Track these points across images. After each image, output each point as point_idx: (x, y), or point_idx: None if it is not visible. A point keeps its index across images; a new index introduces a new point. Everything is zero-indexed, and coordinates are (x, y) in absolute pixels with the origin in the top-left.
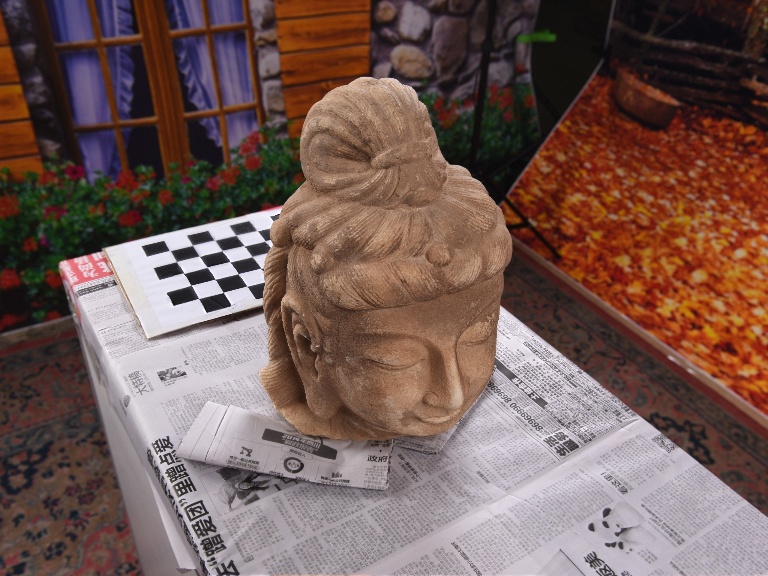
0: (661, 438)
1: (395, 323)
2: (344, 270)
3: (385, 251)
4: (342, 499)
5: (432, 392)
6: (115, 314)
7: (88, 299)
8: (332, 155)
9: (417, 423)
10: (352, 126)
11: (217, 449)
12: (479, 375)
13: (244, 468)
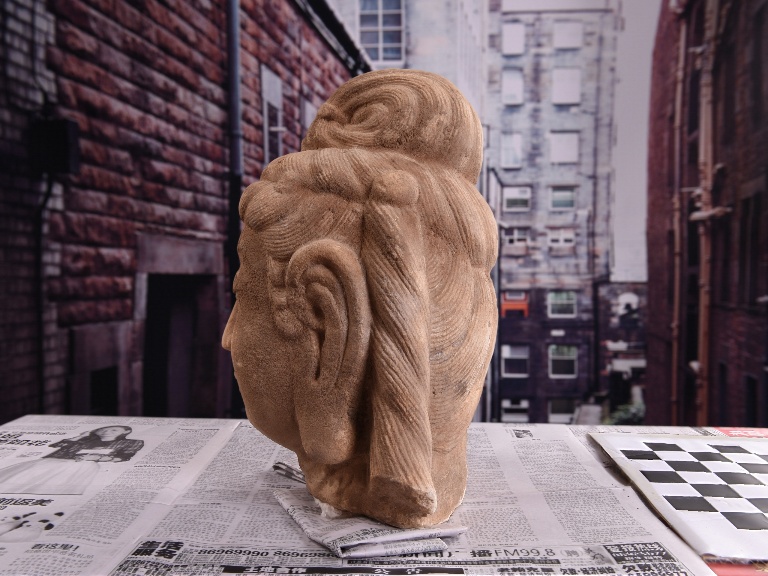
0: None
1: None
2: None
3: None
4: None
5: None
6: (645, 431)
7: None
8: None
9: None
10: None
11: None
12: None
13: None
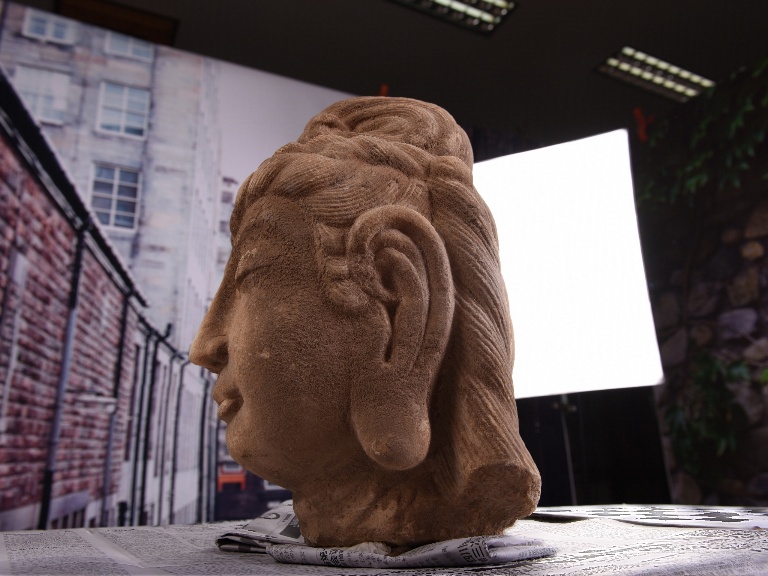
0: None
1: None
2: None
3: None
4: None
5: None
6: None
7: None
8: None
9: None
10: None
11: None
12: None
13: None
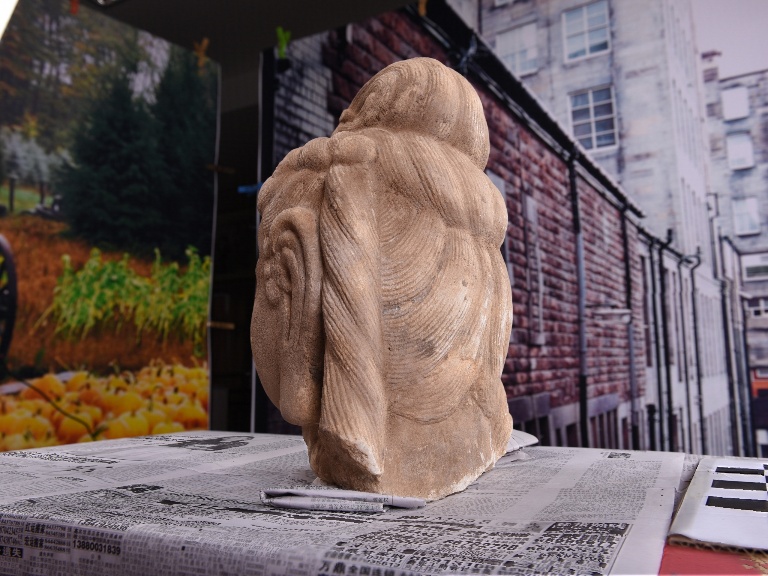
0: None
1: None
2: None
3: None
4: None
5: None
6: None
7: None
8: None
9: None
10: None
11: None
12: None
13: None
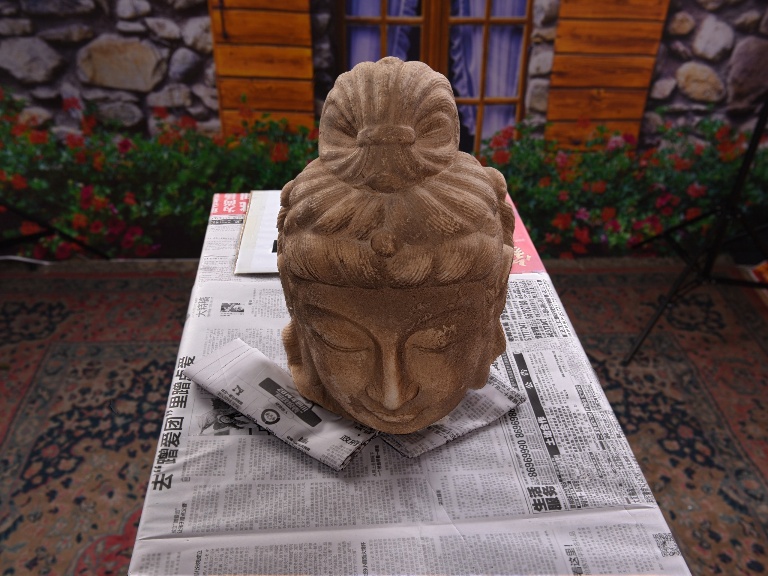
0: (665, 537)
1: (333, 301)
2: (300, 237)
3: (333, 227)
4: (297, 463)
5: (373, 385)
6: (225, 246)
7: (213, 229)
8: (334, 127)
9: (369, 414)
10: (348, 100)
11: (216, 379)
12: (433, 386)
13: (229, 403)
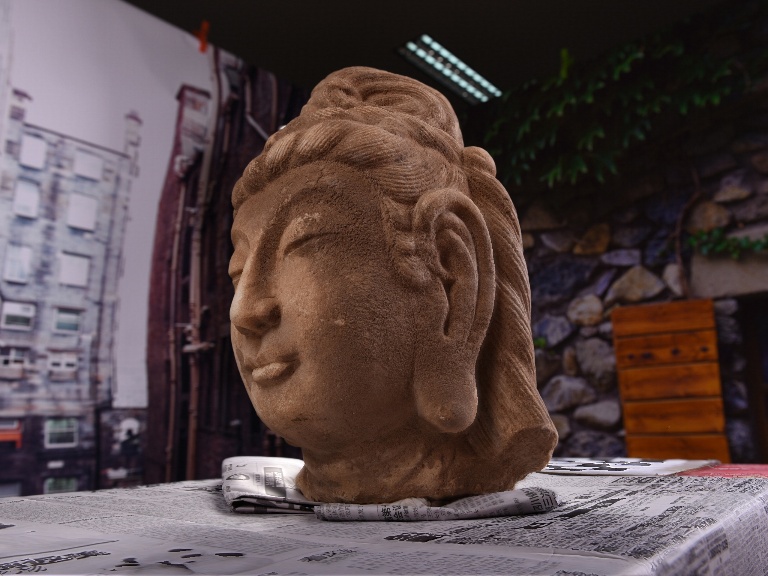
0: (586, 575)
1: None
2: None
3: None
4: (210, 506)
5: None
6: None
7: None
8: None
9: None
10: None
11: None
12: (293, 303)
13: None
